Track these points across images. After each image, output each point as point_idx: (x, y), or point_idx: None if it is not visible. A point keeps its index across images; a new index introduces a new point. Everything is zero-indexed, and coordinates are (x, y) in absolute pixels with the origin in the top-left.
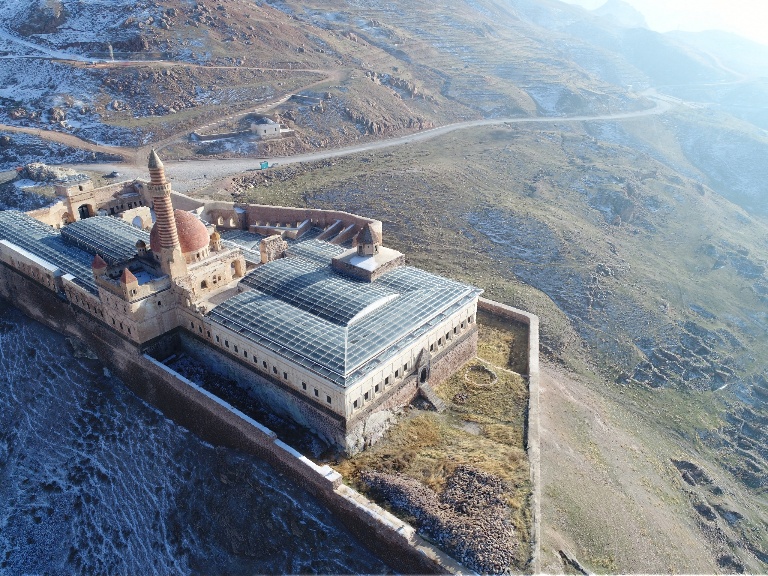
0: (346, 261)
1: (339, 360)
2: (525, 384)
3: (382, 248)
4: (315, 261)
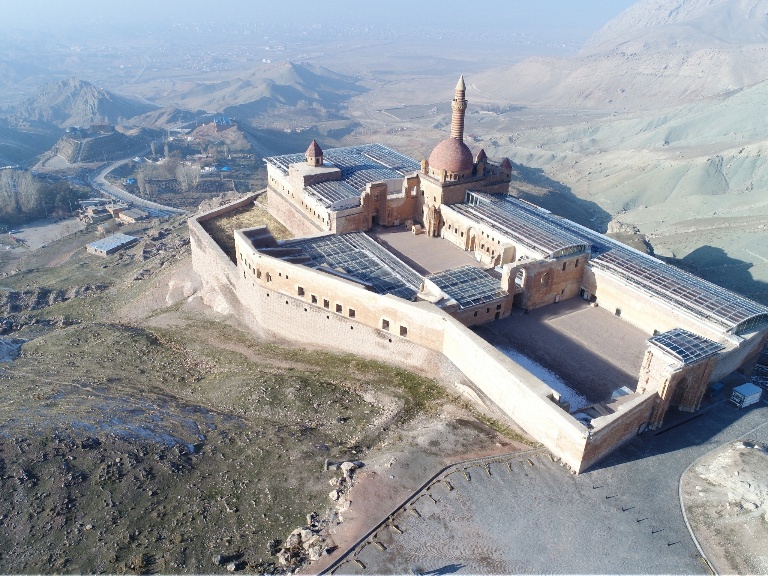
0: (334, 166)
1: (375, 145)
2: (262, 194)
3: (300, 167)
4: (348, 185)
